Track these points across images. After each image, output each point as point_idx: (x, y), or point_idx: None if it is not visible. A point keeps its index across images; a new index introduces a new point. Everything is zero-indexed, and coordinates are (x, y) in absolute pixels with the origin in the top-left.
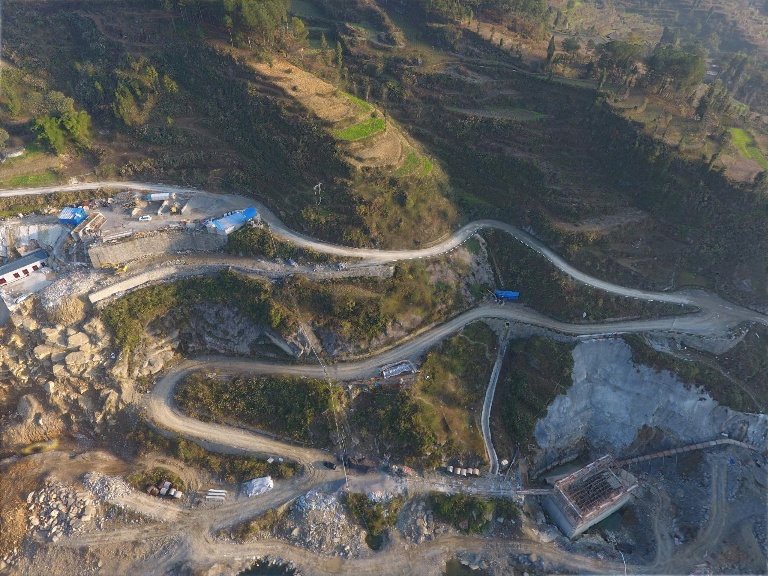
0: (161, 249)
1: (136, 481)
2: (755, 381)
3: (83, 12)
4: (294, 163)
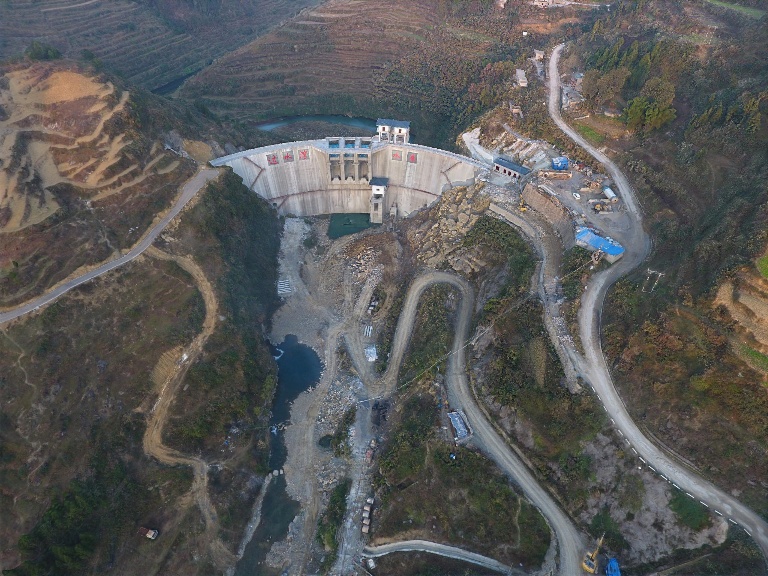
0: (553, 220)
1: None
2: None
3: None
4: (697, 249)
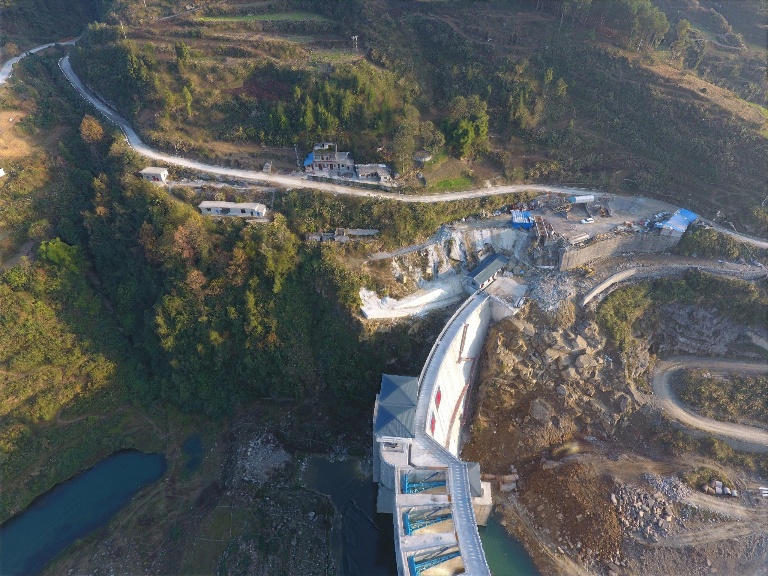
0: (609, 251)
1: (693, 481)
2: None
3: (423, 14)
4: (724, 165)
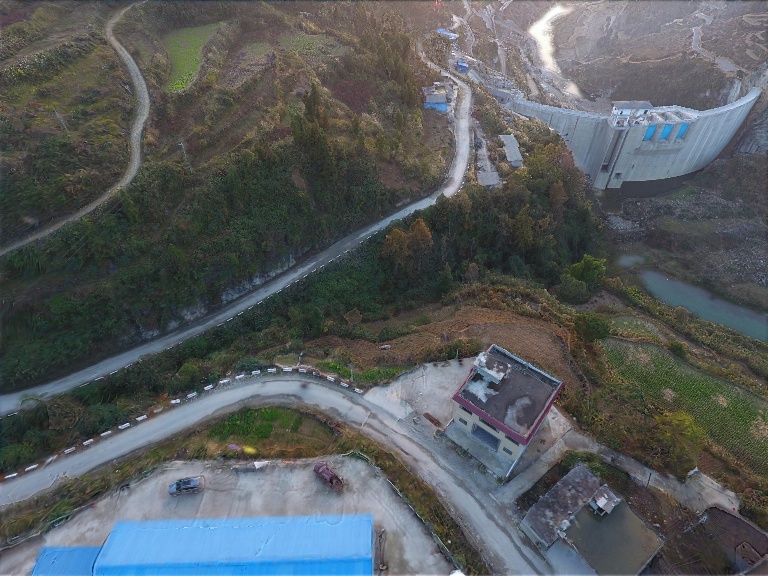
0: None
1: None
2: (478, 2)
3: None
4: (417, 2)
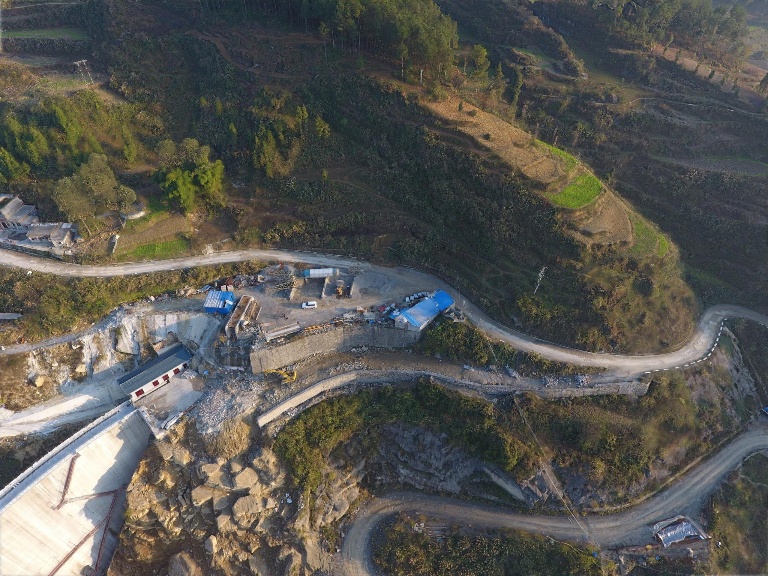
0: (332, 346)
1: None
2: None
3: (197, 33)
4: (496, 235)
